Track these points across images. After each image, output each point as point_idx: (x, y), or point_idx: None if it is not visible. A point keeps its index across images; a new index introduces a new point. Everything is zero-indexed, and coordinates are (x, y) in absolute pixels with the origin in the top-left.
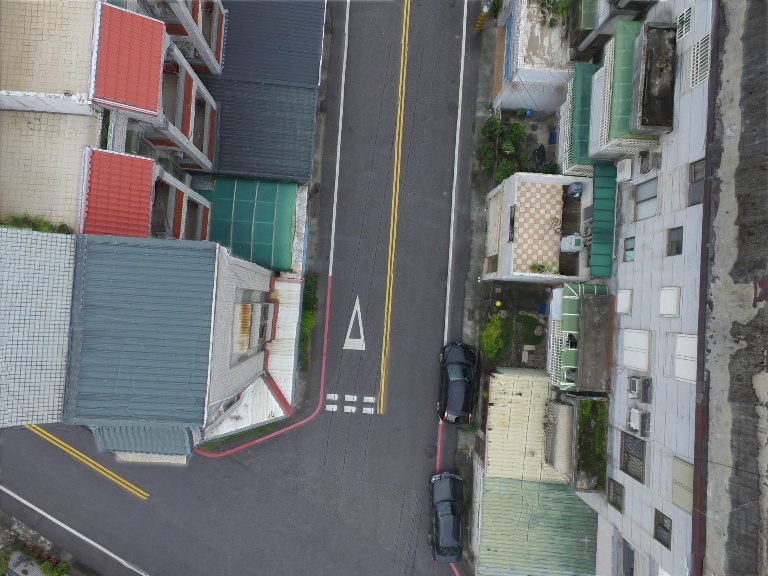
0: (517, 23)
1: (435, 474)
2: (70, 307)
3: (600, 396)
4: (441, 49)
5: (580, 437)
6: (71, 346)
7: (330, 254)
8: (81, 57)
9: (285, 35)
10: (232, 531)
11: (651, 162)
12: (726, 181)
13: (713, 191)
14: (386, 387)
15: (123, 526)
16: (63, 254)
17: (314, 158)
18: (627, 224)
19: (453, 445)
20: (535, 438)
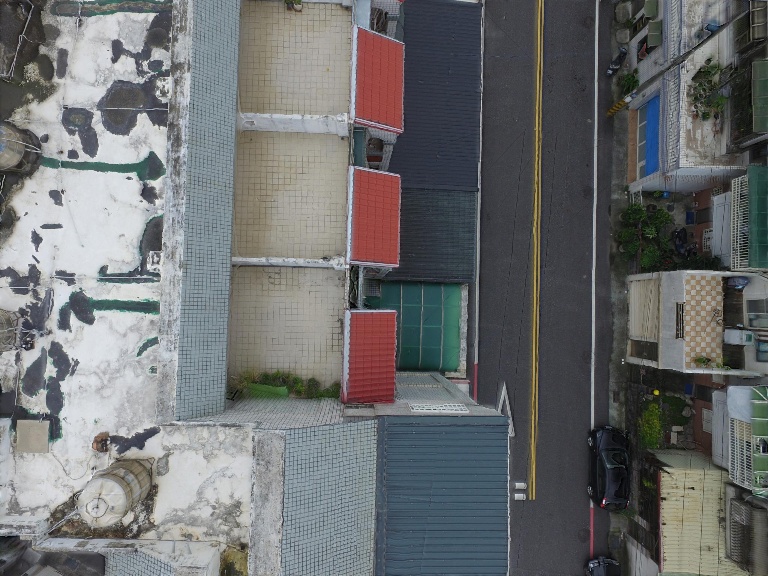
0: (670, 118)
1: (591, 559)
2: (375, 490)
3: None
4: (574, 134)
5: None
6: (377, 528)
7: (475, 342)
8: (317, 210)
9: (444, 140)
10: None
11: None
12: None
13: None
14: (537, 473)
15: None
16: (369, 440)
17: None
18: None
19: (605, 528)
20: (710, 531)
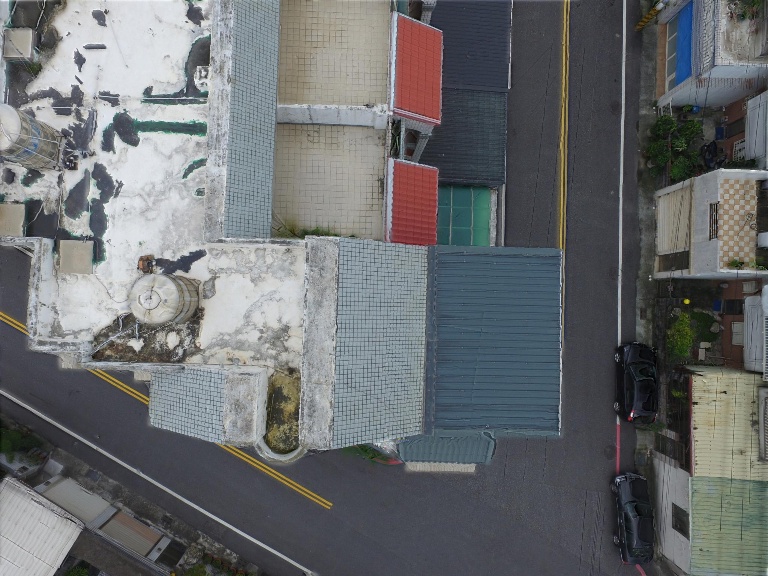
0: (704, 20)
1: (618, 475)
2: (425, 318)
3: None
4: (602, 48)
5: None
6: (427, 357)
7: None
8: (356, 68)
9: (474, 40)
10: (417, 538)
11: None
12: None
13: None
14: (563, 389)
15: (307, 536)
16: (420, 265)
17: None
18: None
19: (632, 445)
20: (742, 436)
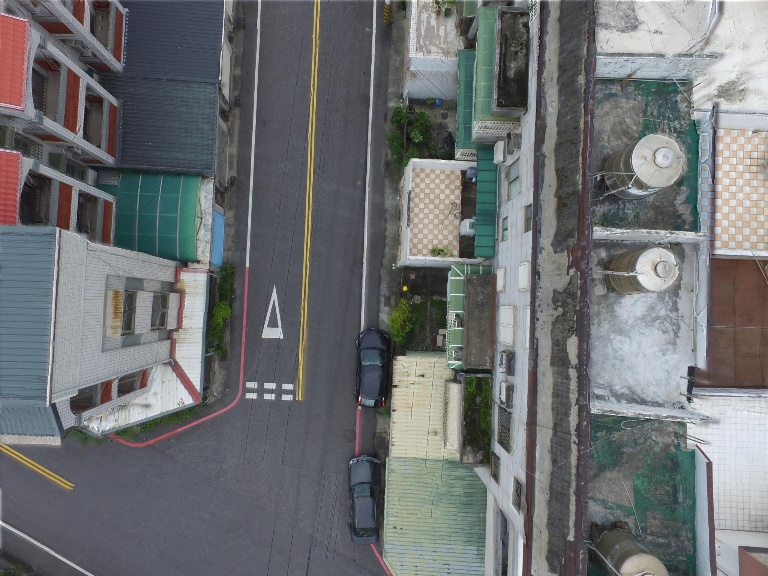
0: None
1: (353, 457)
2: None
3: (484, 373)
4: (352, 42)
5: (466, 413)
6: None
7: (247, 245)
8: None
9: (185, 32)
10: (156, 518)
11: (512, 143)
12: (549, 156)
13: (540, 166)
14: (304, 374)
15: (50, 516)
16: None
17: (229, 152)
18: (503, 205)
19: (372, 429)
20: (438, 418)
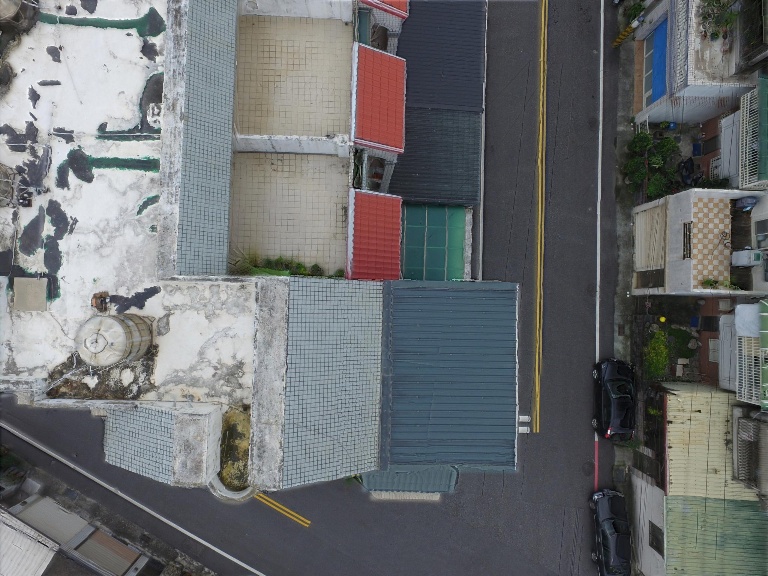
0: (678, 39)
1: (596, 492)
2: (380, 354)
3: None
4: (580, 65)
5: None
6: (383, 393)
7: (479, 274)
8: (320, 96)
9: (448, 59)
10: (395, 556)
11: None
12: None
13: None
14: (541, 406)
15: (285, 554)
16: (375, 301)
17: None
18: None
19: (610, 462)
20: (717, 455)
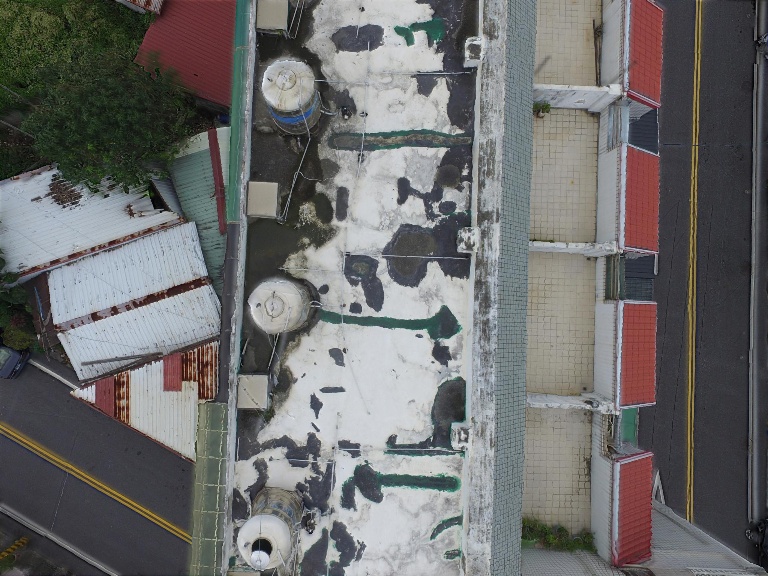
0: None
1: None
2: None
3: None
4: (731, 206)
5: None
6: None
7: None
8: (561, 338)
9: None
10: None
11: None
12: None
13: None
14: None
15: None
16: None
17: None
18: None
19: None
20: None
